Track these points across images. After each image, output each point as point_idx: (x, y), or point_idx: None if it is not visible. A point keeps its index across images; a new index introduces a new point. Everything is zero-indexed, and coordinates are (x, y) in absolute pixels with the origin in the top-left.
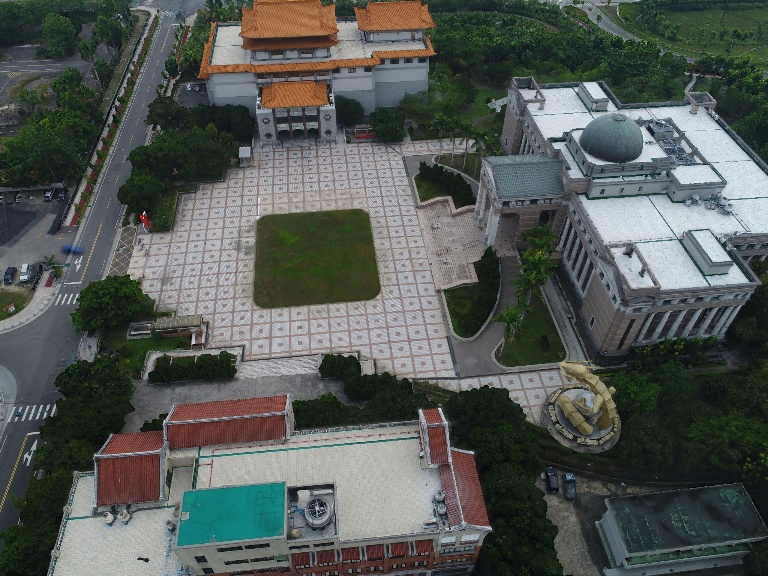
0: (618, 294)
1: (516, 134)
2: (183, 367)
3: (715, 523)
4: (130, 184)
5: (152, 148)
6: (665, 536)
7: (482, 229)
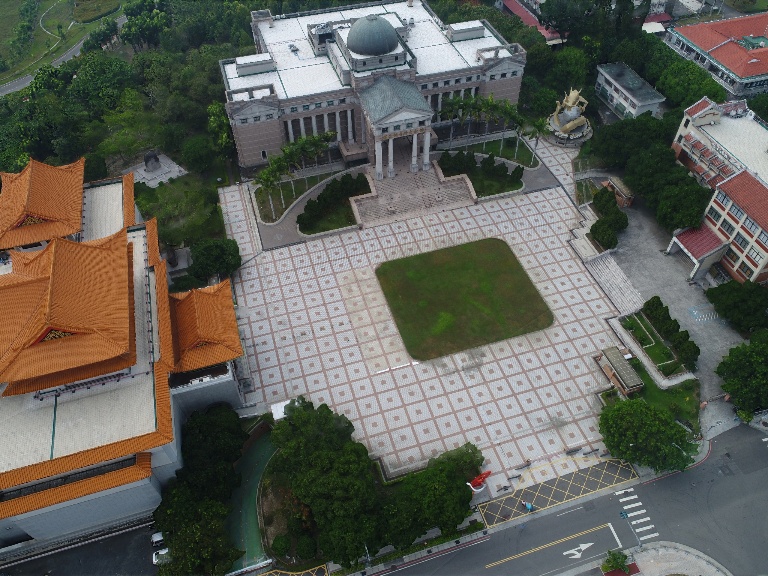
0: (521, 65)
1: (281, 132)
2: (676, 333)
3: (626, 75)
4: (448, 496)
5: (362, 490)
6: (645, 89)
7: (397, 174)
